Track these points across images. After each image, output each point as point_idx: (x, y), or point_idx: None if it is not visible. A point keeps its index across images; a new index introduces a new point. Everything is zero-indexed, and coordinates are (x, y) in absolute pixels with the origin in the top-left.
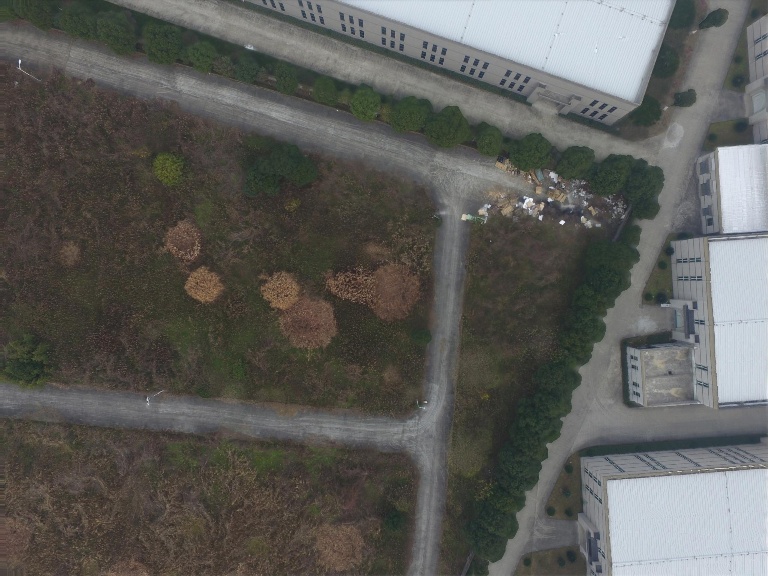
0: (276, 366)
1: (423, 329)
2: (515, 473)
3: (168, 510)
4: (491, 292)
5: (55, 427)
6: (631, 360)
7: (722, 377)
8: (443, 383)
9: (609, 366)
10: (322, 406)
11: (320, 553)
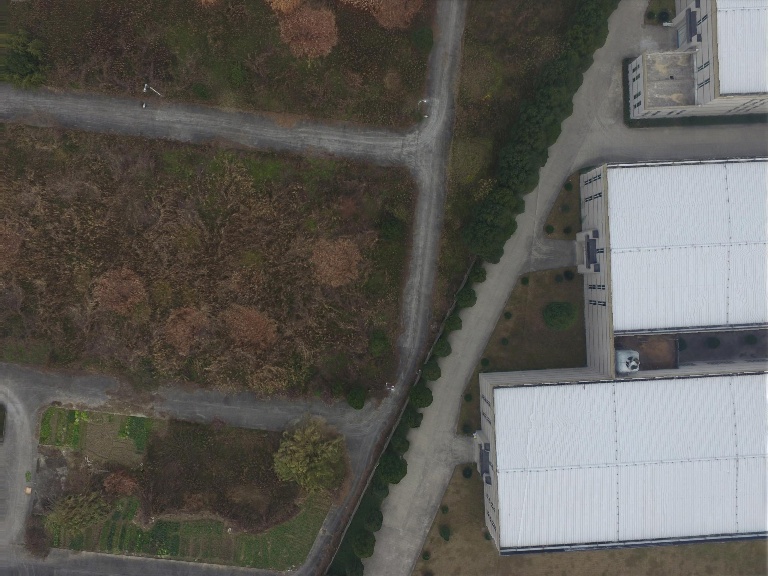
0: (276, 72)
1: (425, 27)
2: (515, 163)
3: (162, 215)
4: (494, 6)
5: (49, 131)
6: (633, 74)
7: (724, 66)
8: (444, 98)
9: (610, 86)
10: (321, 116)
11: (316, 268)
